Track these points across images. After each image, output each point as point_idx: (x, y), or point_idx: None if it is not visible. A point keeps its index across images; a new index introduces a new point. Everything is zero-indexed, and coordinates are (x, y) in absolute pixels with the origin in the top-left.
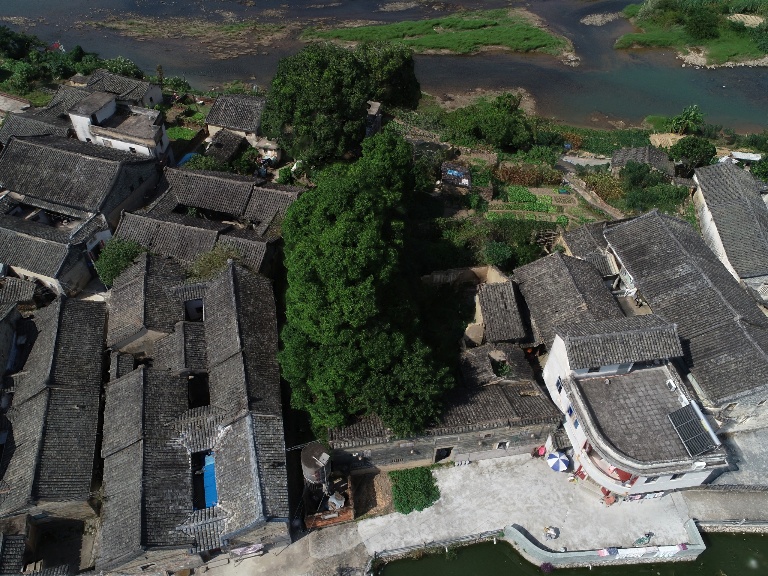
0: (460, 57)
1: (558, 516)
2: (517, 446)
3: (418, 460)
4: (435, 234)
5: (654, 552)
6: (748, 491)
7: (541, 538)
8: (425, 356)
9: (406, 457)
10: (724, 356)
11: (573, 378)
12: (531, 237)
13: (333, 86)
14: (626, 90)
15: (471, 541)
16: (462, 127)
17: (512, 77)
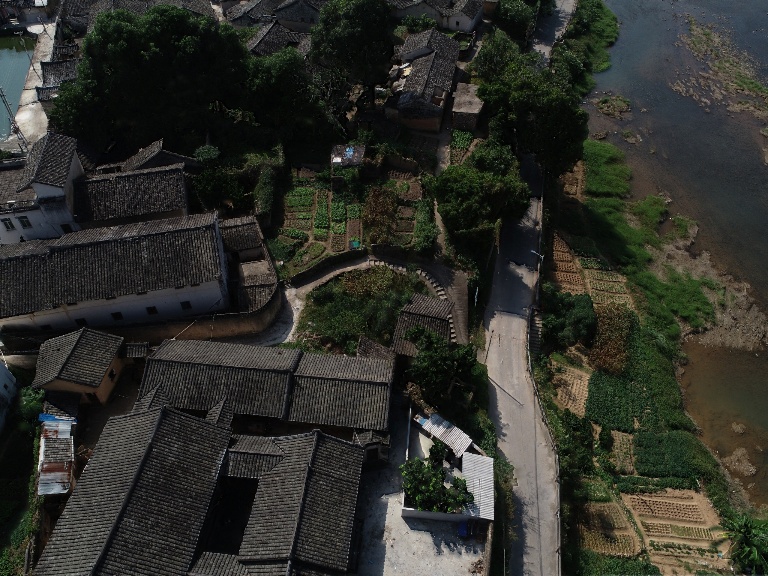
0: None
1: None
2: None
3: None
4: None
5: None
6: None
7: None
8: (87, 103)
9: None
10: None
11: None
12: None
13: (331, 10)
14: None
15: None
16: None
17: None
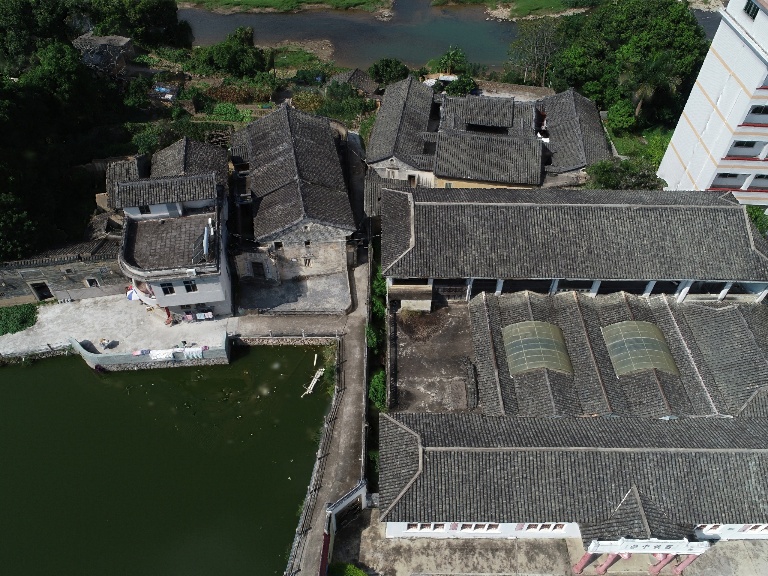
0: (282, 15)
1: (124, 334)
2: (109, 285)
3: (20, 296)
4: (127, 138)
5: (181, 352)
6: (294, 315)
7: (101, 348)
8: (12, 205)
9: (6, 292)
10: (278, 206)
11: (126, 218)
12: (205, 137)
13: (16, 5)
14: (424, 40)
15: (46, 353)
16: (201, 58)
17: (322, 31)
